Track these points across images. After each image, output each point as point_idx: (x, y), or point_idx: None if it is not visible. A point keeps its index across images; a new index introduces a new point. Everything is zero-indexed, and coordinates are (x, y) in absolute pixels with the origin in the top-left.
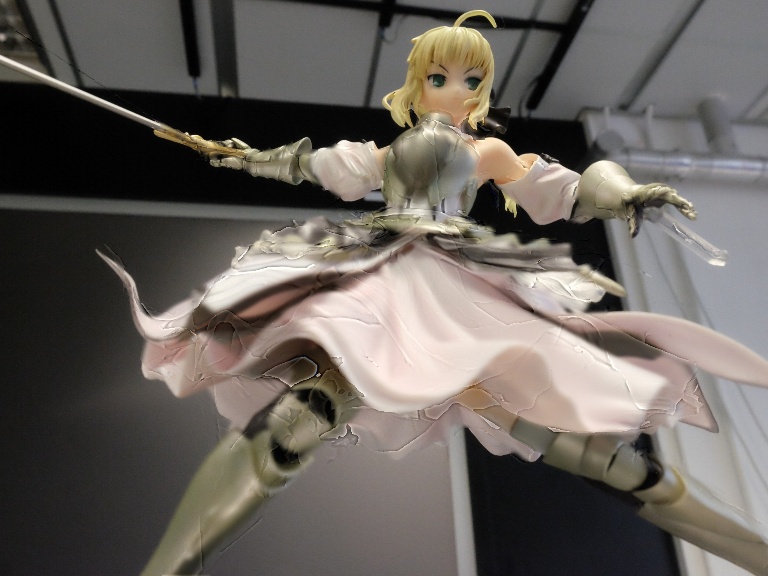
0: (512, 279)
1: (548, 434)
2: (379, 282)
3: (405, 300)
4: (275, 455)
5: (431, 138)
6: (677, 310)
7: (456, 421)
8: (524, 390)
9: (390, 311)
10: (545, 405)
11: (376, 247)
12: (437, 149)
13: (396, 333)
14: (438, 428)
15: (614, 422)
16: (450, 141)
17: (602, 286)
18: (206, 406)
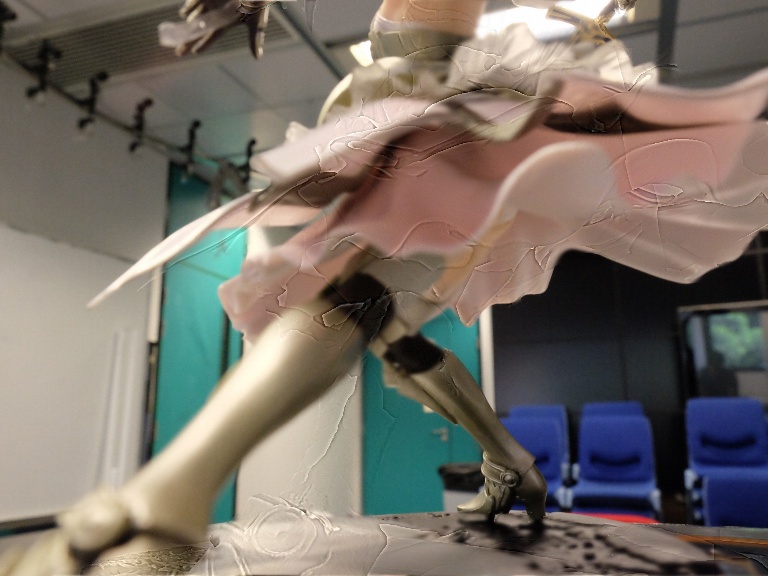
0: None
1: None
2: None
3: None
4: None
5: None
6: None
7: (767, 135)
8: None
9: None
10: None
11: None
12: None
13: None
14: (762, 162)
15: None
16: None
17: None
18: None
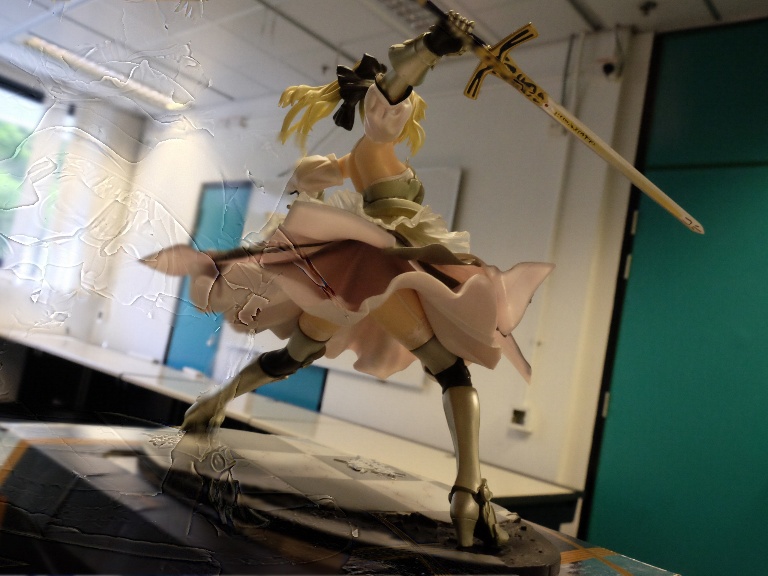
0: None
1: (78, 284)
2: None
3: None
4: None
5: None
6: None
7: None
8: (186, 308)
9: None
10: (184, 318)
11: None
12: None
13: None
14: None
15: None
16: None
17: None
18: (36, 159)
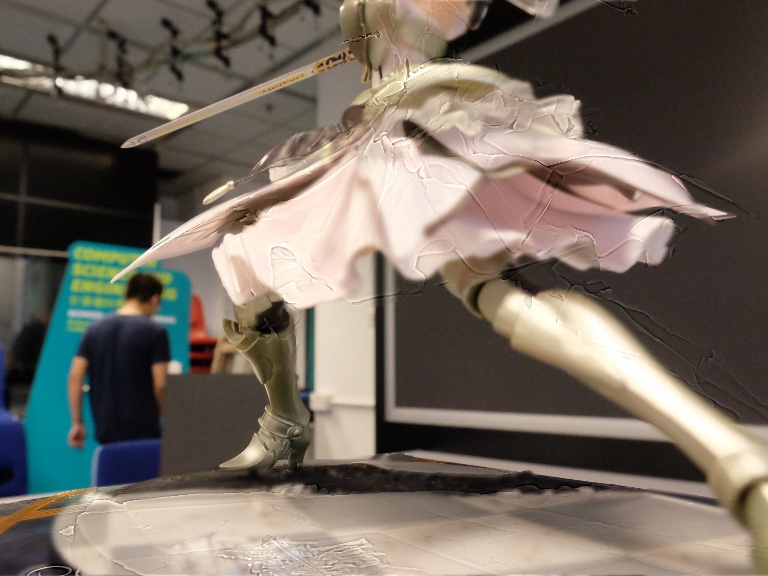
0: (408, 148)
1: None
2: (285, 209)
3: (330, 203)
4: (274, 330)
5: (375, 10)
6: (436, 174)
7: None
8: None
9: (248, 249)
10: None
11: (338, 152)
12: (382, 18)
13: (250, 264)
14: None
15: (402, 297)
16: (387, 3)
17: (484, 121)
18: None
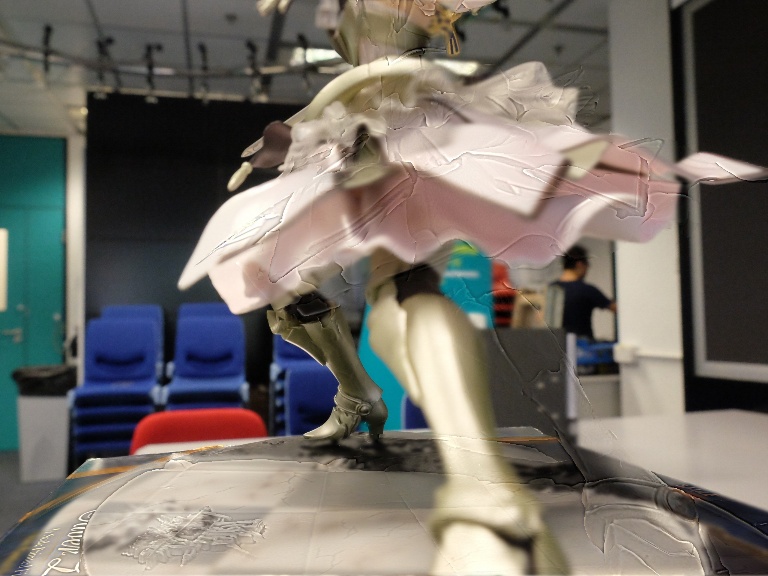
0: None
1: None
2: None
3: None
4: (320, 320)
5: None
6: None
7: None
8: None
9: None
10: None
11: None
12: None
13: None
14: None
15: None
16: None
17: (388, 126)
18: None
